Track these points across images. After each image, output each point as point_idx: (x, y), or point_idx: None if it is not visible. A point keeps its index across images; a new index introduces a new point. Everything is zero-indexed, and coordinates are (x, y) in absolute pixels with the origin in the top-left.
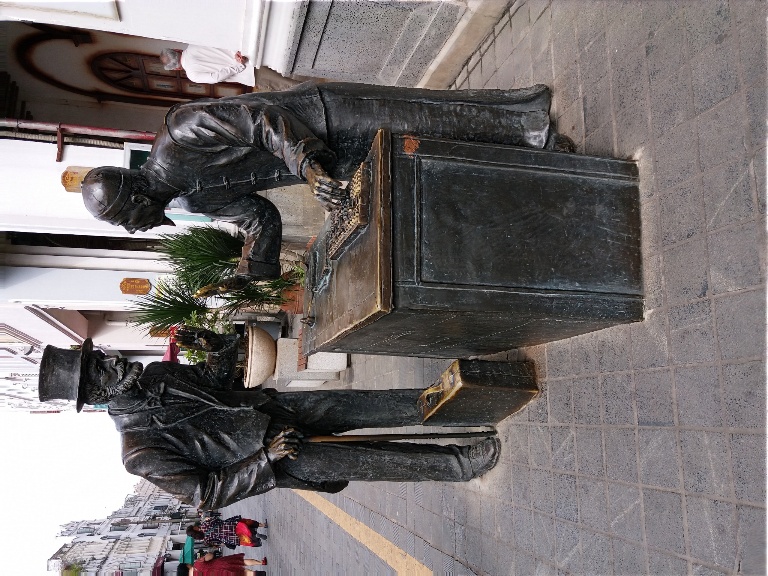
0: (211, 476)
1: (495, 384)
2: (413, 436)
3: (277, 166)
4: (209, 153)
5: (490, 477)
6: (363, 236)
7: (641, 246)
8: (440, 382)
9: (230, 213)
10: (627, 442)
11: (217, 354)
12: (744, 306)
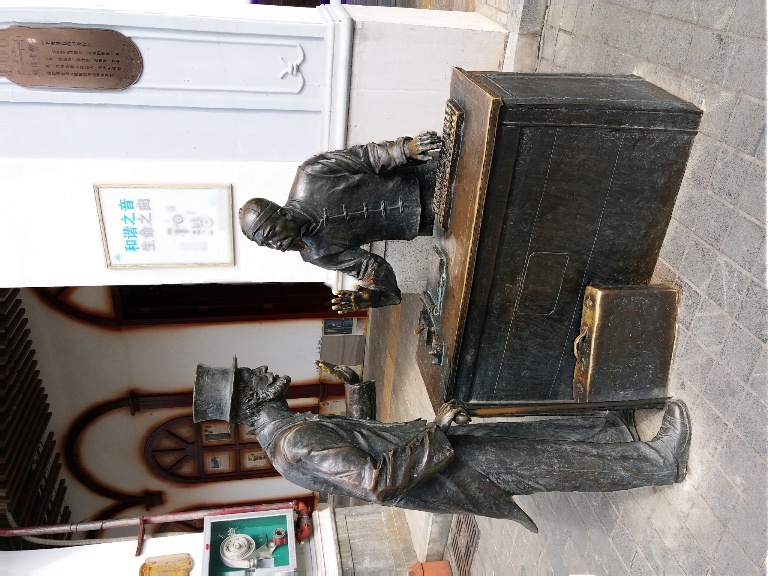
0: None
1: (632, 288)
2: (583, 404)
3: (382, 197)
4: (332, 178)
5: (695, 450)
6: (463, 131)
7: (670, 93)
8: (583, 328)
9: (349, 257)
10: (758, 178)
11: (357, 386)
12: (743, 2)
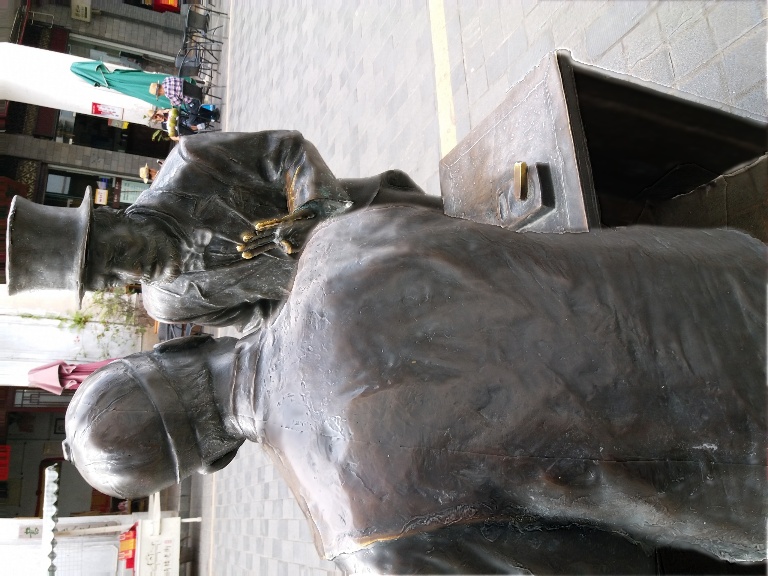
0: (257, 316)
1: None
2: None
3: None
4: None
5: None
6: None
7: None
8: None
9: None
10: None
11: None
12: None
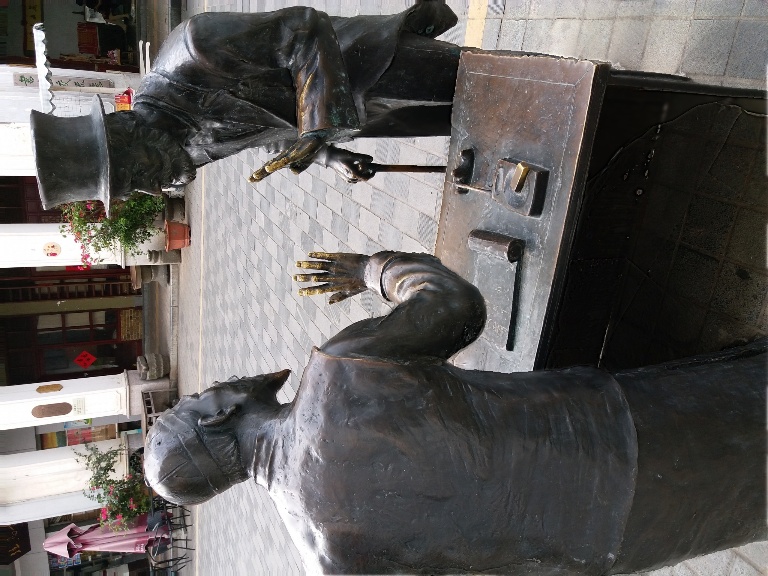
0: None
1: None
2: None
3: None
4: None
5: None
6: None
7: None
8: None
9: None
10: None
11: None
12: None
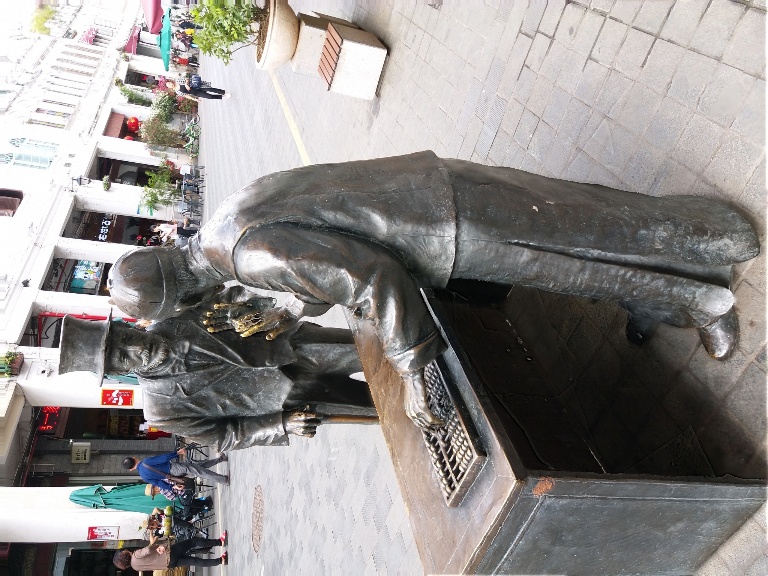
0: (229, 431)
1: None
2: None
3: None
4: None
5: None
6: None
7: (723, 544)
8: None
9: None
10: None
11: None
12: None
